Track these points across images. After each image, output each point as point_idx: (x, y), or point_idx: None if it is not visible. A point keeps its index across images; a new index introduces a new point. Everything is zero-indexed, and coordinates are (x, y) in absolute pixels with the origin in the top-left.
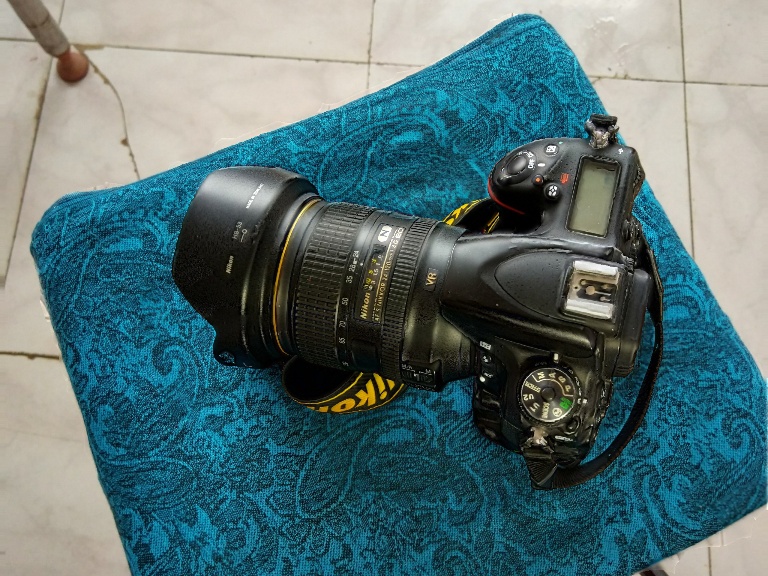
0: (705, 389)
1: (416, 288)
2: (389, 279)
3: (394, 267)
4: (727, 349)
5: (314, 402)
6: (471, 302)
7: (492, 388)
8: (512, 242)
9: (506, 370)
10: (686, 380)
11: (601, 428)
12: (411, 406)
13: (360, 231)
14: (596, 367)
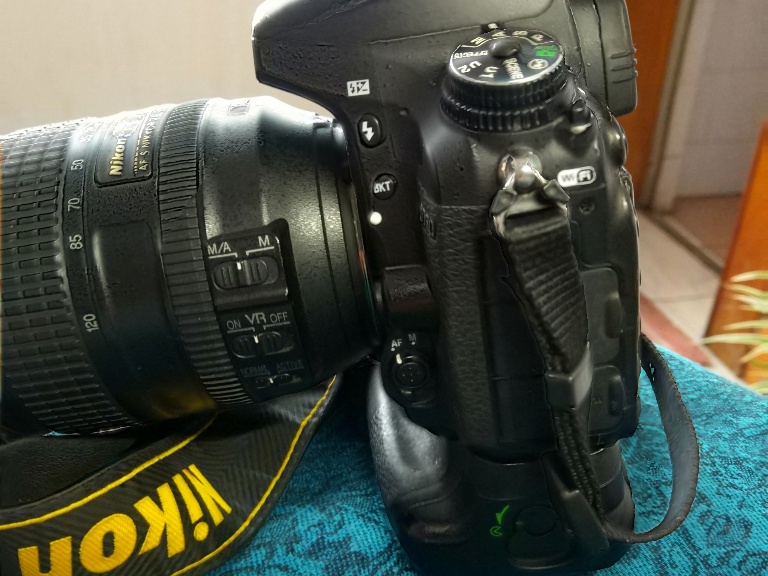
0: (758, 436)
1: (213, 115)
2: (162, 119)
3: (170, 111)
4: (750, 394)
5: (33, 514)
6: (310, 7)
7: (401, 243)
8: None
9: (411, 116)
10: (723, 432)
11: (636, 520)
12: (265, 563)
13: None
14: (571, 39)
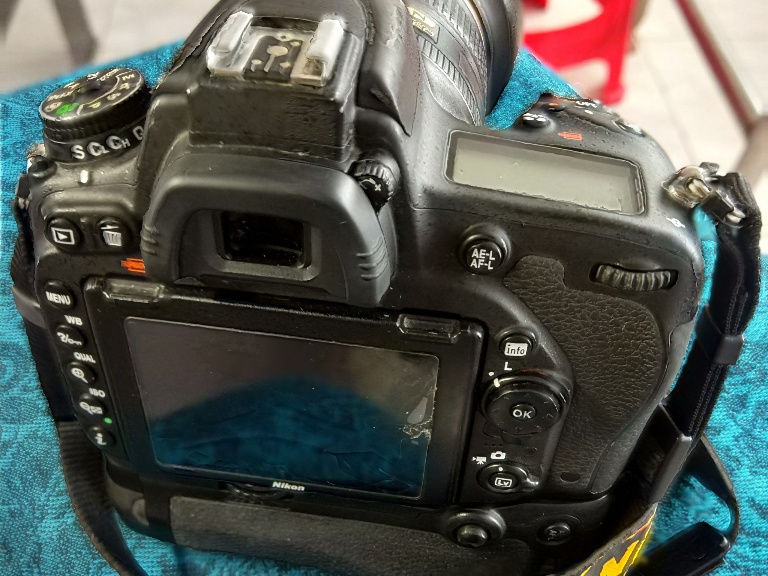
0: None
1: None
2: None
3: None
4: None
5: None
6: None
7: None
8: (388, 7)
9: None
10: None
11: None
12: None
13: (420, 2)
14: None
